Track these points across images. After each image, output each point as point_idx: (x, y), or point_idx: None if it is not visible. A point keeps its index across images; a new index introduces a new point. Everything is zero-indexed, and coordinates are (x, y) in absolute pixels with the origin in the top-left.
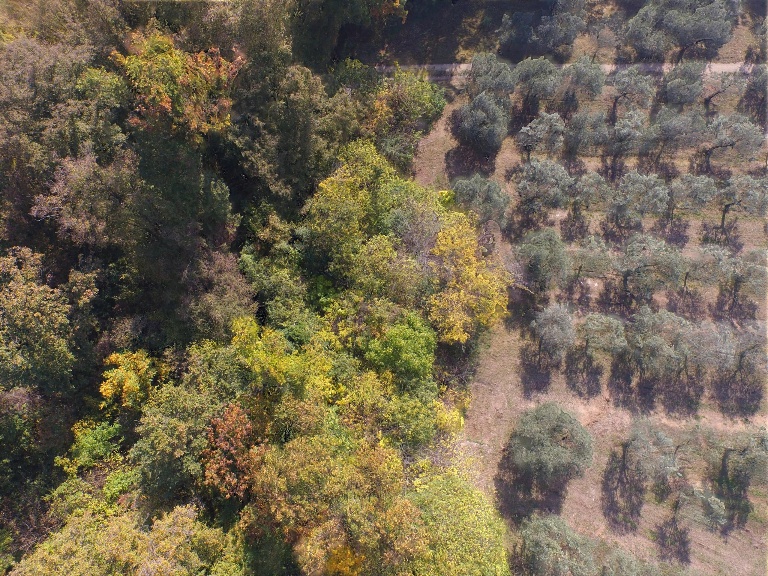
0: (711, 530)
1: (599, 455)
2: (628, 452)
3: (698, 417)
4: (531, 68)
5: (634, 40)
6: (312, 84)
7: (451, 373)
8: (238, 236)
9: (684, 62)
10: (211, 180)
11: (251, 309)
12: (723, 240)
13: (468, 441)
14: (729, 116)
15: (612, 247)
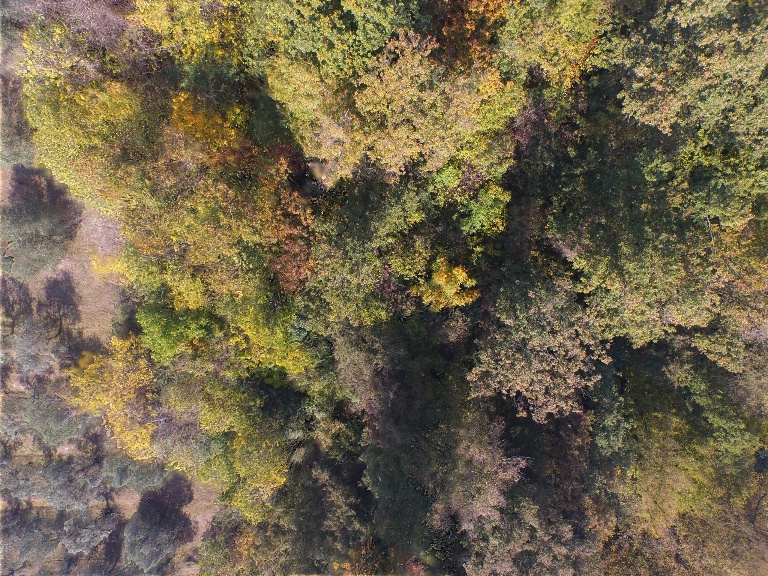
0: None
1: None
2: None
3: None
4: None
5: None
6: None
7: None
8: None
9: None
10: None
11: None
12: None
13: (118, 228)
14: None
15: None
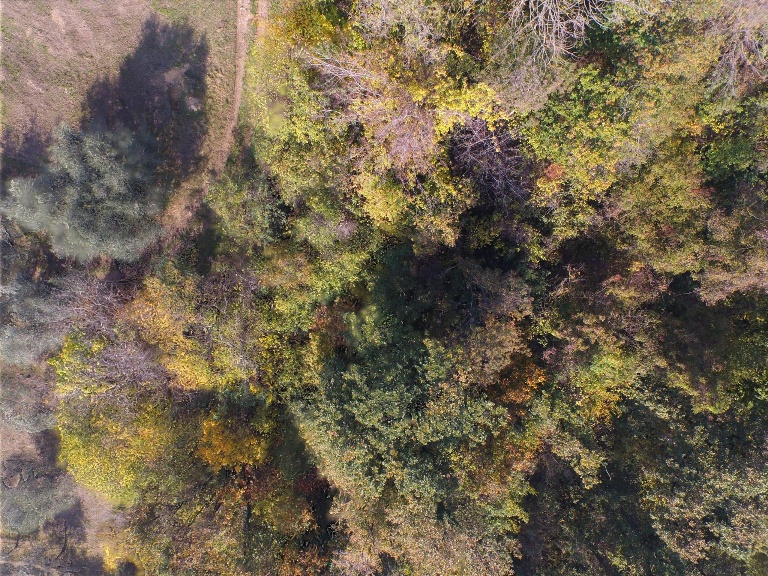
0: None
1: (1, 448)
2: None
3: None
4: None
5: None
6: None
7: None
8: None
9: None
10: None
11: None
12: None
13: None
14: None
15: None
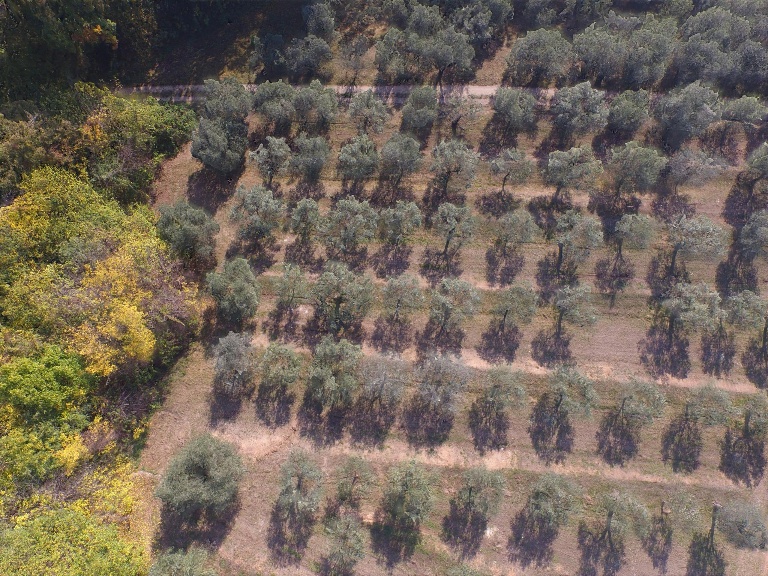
0: (377, 562)
1: (274, 485)
2: (303, 483)
3: (383, 447)
4: (263, 92)
5: None
6: None
7: (114, 404)
8: None
9: (442, 84)
10: None
11: None
12: (443, 267)
13: (142, 471)
14: None
15: None
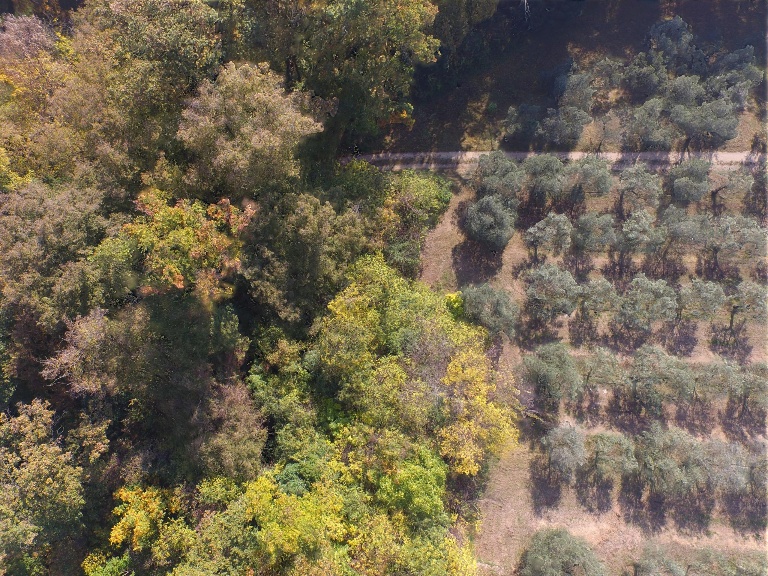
0: None
1: (610, 575)
2: (639, 572)
3: (709, 533)
4: (538, 167)
5: (640, 134)
6: (321, 217)
7: (462, 498)
8: (247, 355)
9: (690, 151)
10: (221, 319)
11: (261, 437)
12: (732, 342)
13: (479, 562)
14: (737, 218)
15: (621, 351)
